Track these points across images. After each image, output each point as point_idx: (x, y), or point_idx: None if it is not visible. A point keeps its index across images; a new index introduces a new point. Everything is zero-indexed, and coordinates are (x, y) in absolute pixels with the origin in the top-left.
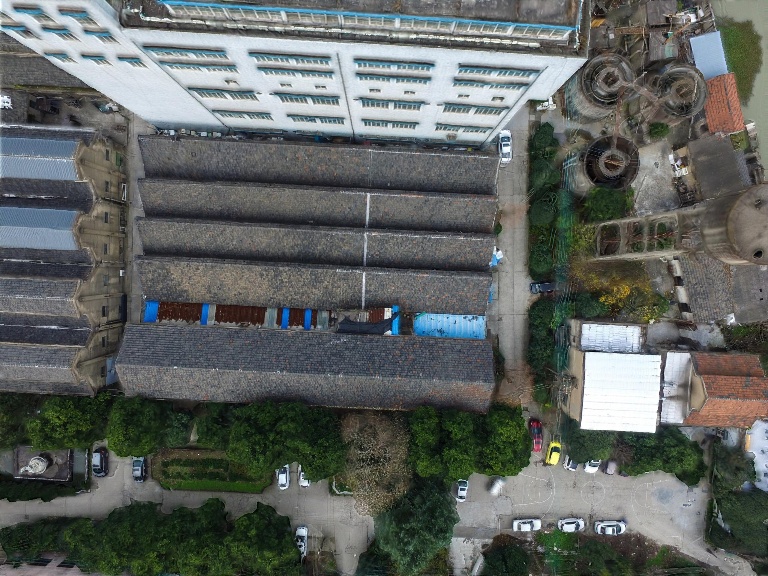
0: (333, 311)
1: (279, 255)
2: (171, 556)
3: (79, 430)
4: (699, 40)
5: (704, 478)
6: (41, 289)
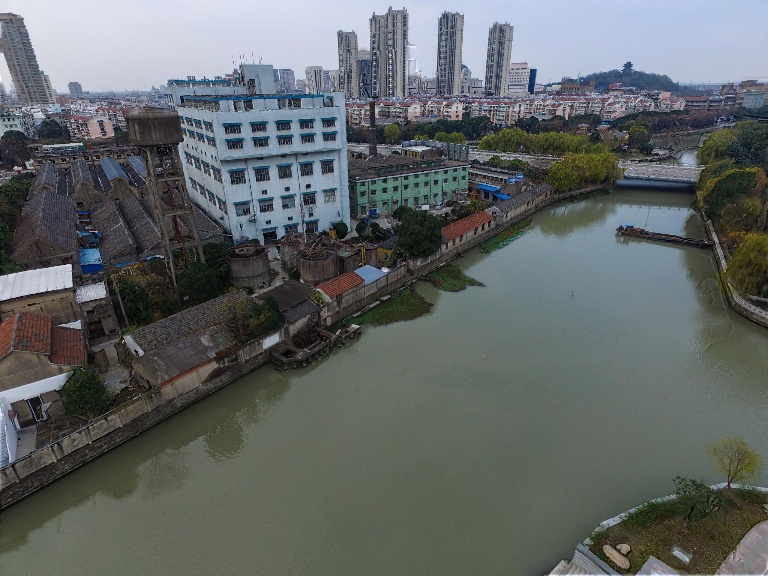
0: None
1: None
2: None
3: None
4: (371, 268)
5: None
6: None
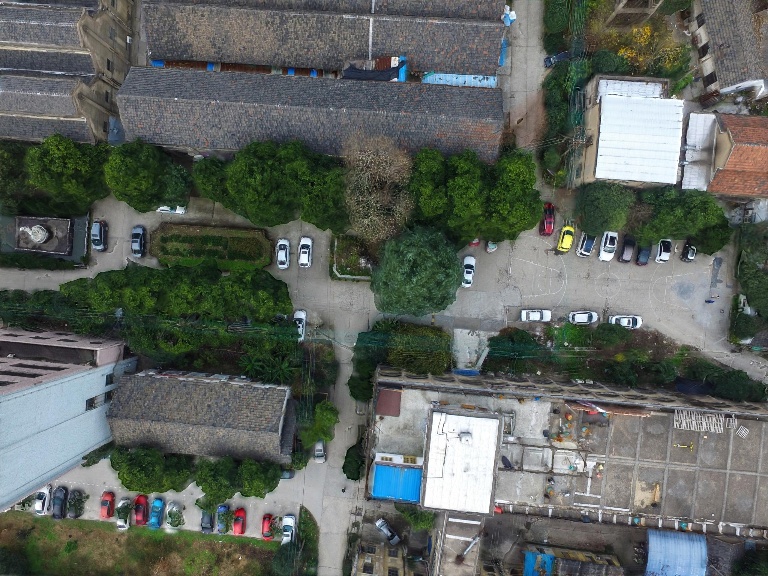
0: (339, 72)
1: (285, 8)
2: (164, 302)
3: (78, 170)
4: None
5: (729, 272)
6: (46, 16)
